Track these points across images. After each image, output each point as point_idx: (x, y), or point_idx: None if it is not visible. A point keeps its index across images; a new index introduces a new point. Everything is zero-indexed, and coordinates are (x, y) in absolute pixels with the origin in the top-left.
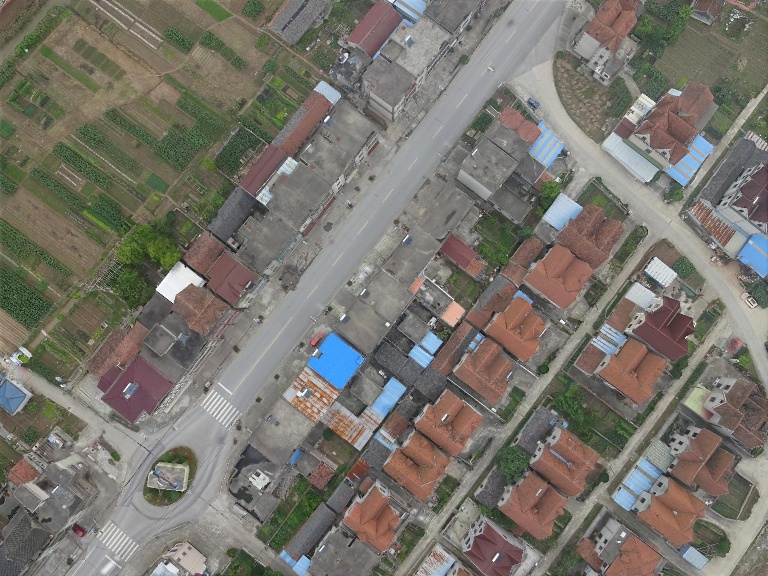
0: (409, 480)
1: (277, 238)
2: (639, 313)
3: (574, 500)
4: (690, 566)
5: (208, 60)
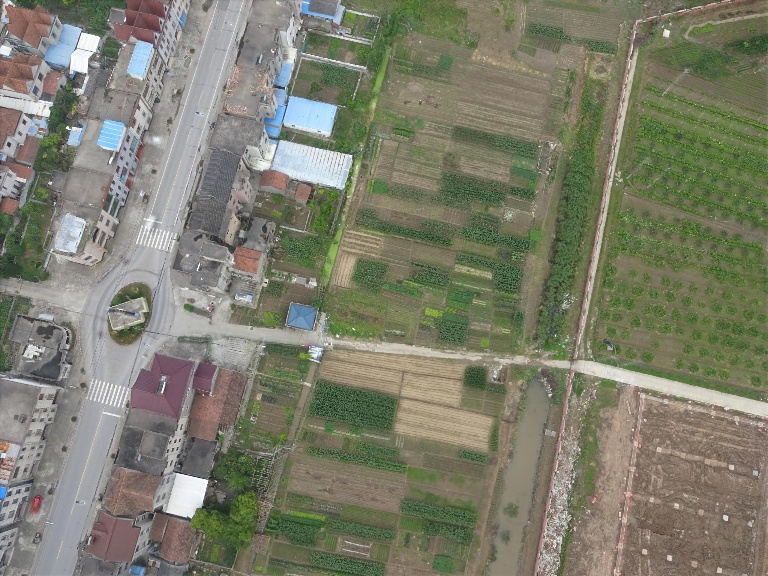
0: None
1: None
2: None
3: None
4: None
5: None
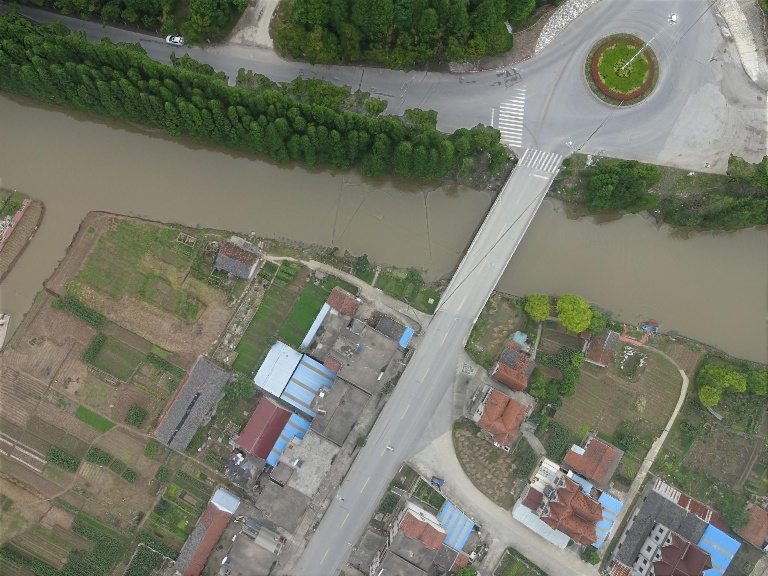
0: None
1: None
2: None
3: None
4: None
5: (97, 476)
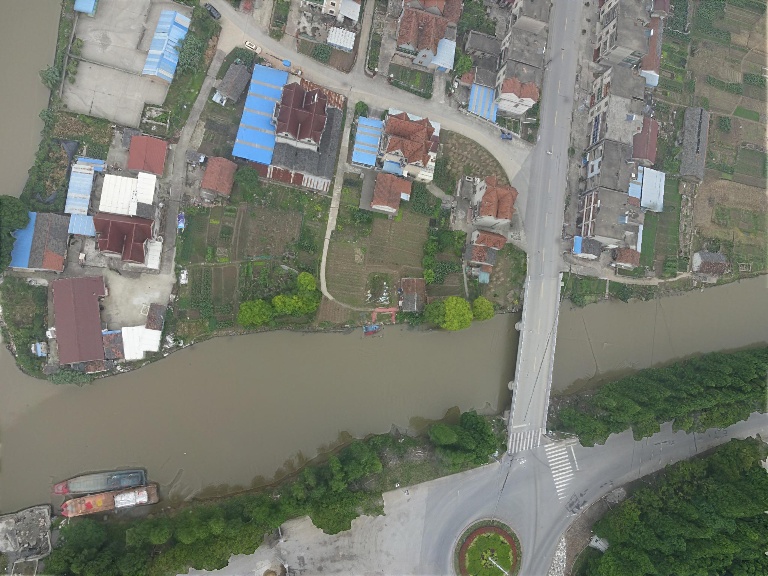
0: None
1: None
2: None
3: None
4: None
5: (729, 75)
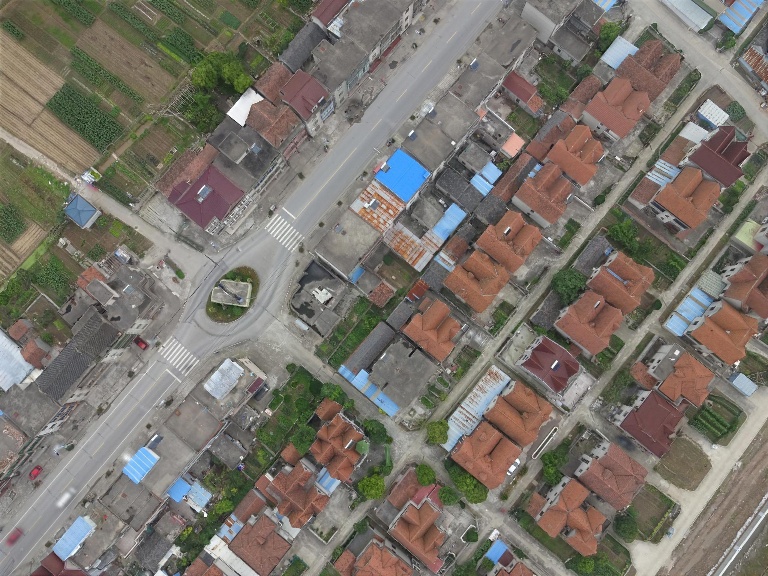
0: (471, 290)
1: (349, 60)
2: (693, 146)
3: (626, 328)
4: (739, 395)
5: None
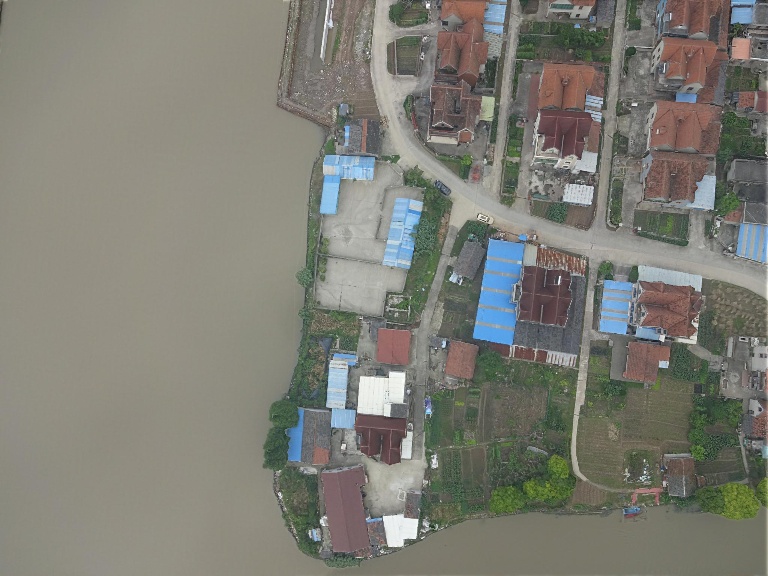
0: None
1: None
2: None
3: None
4: None
5: None
